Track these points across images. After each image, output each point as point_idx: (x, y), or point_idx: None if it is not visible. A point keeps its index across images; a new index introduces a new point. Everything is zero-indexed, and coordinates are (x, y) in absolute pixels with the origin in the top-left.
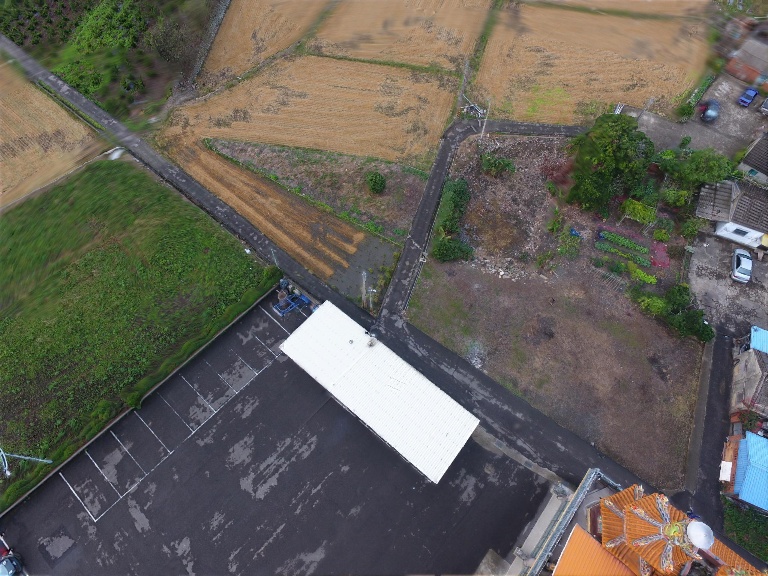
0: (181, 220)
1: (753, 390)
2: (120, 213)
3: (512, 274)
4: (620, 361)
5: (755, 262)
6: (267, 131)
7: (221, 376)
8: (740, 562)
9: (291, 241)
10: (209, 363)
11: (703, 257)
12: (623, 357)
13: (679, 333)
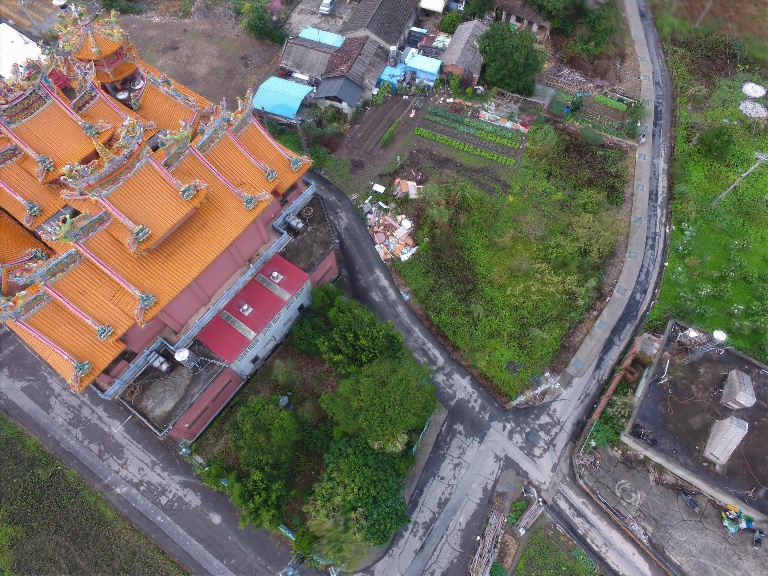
0: None
1: None
2: None
3: (165, 20)
4: (219, 59)
5: (343, 5)
6: None
7: None
8: (153, 69)
9: (5, 8)
10: None
11: (307, 4)
12: (222, 57)
13: (269, 43)
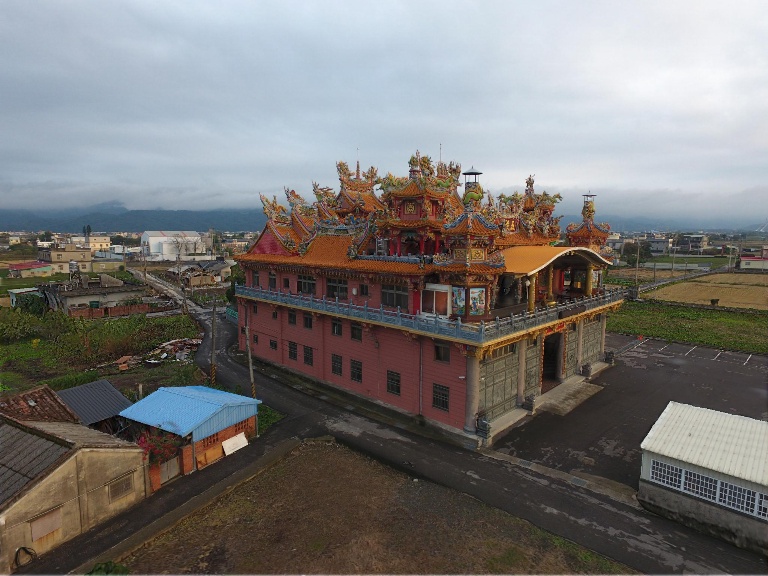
0: None
1: (112, 458)
2: None
3: None
4: None
5: None
6: None
7: None
8: None
9: None
10: None
11: None
12: None
13: None
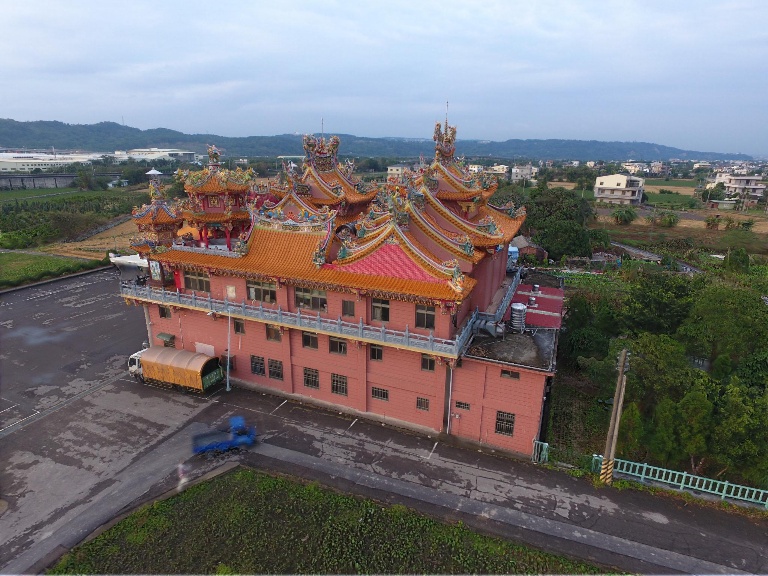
0: (49, 261)
1: None
2: (2, 262)
3: None
4: None
5: None
6: (122, 245)
7: (61, 286)
8: None
9: None
10: (53, 284)
11: None
12: None
13: None
